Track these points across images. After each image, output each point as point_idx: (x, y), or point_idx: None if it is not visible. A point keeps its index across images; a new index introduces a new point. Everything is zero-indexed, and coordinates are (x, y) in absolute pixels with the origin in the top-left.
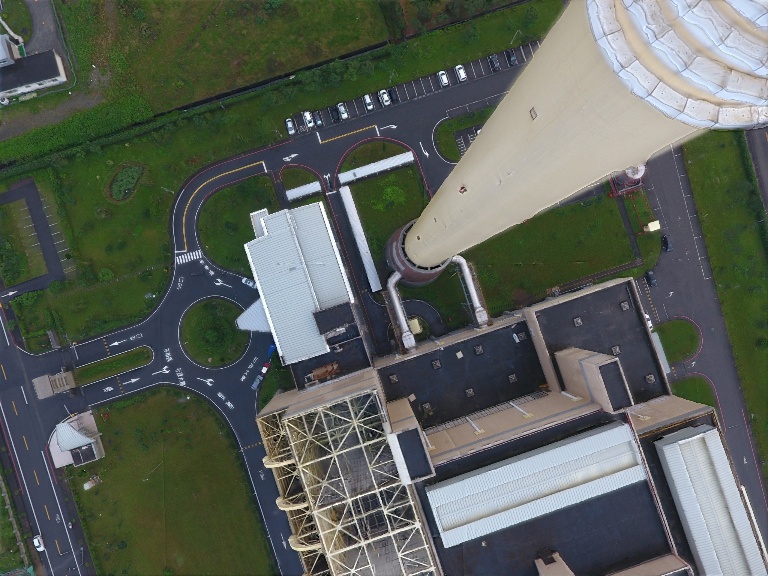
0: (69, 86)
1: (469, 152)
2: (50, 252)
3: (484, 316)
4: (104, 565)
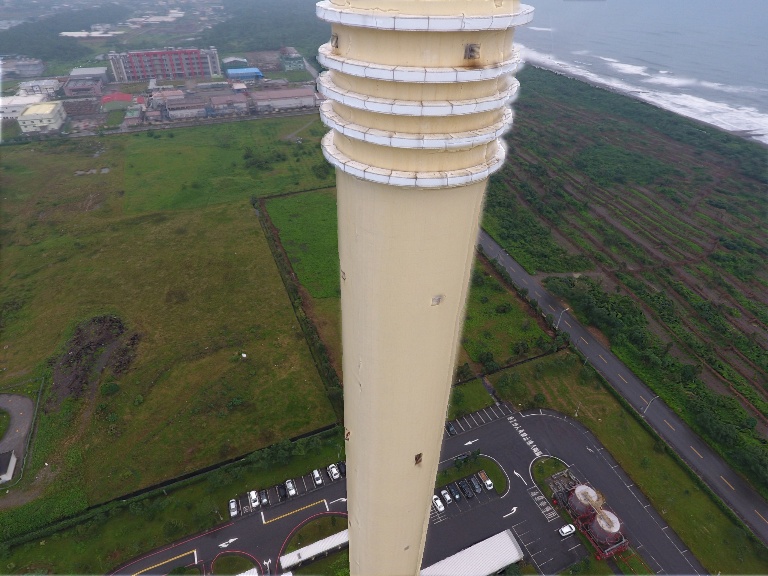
0: (10, 485)
1: None
2: None
3: None
4: None
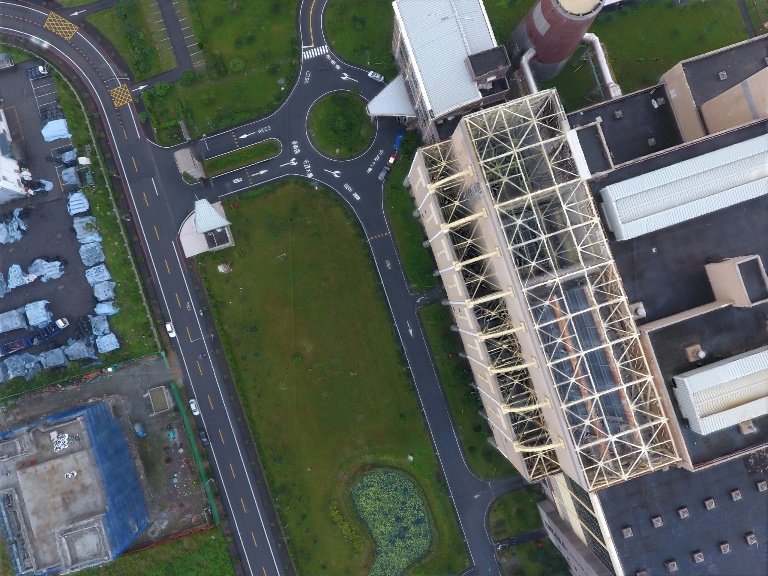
0: None
1: None
2: (180, 46)
3: (618, 91)
4: (234, 351)
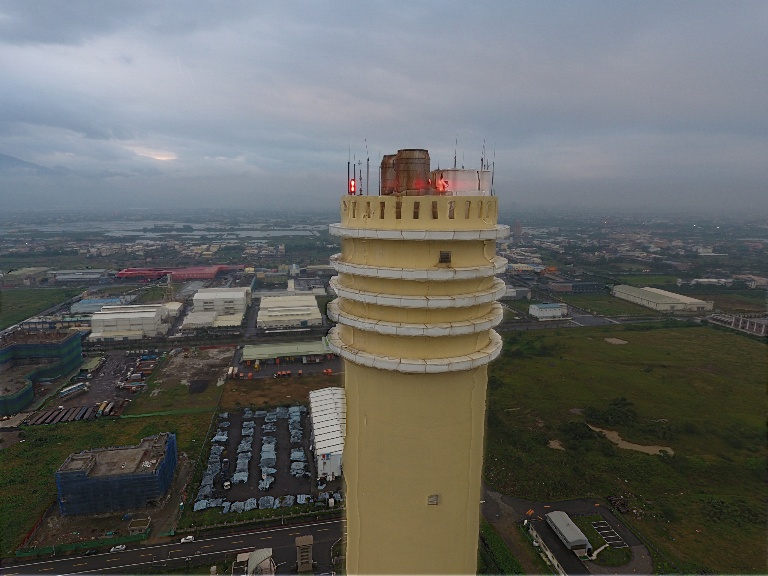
0: None
1: None
2: None
3: None
4: None
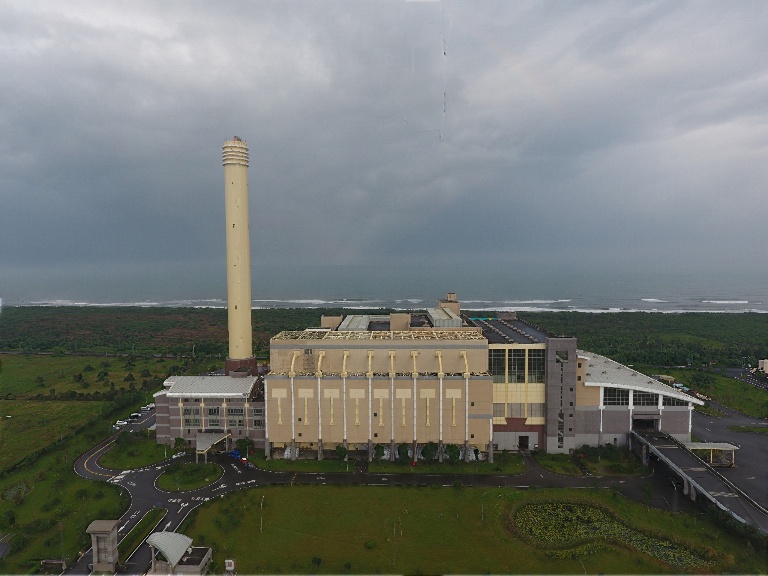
0: None
1: (228, 219)
2: None
3: None
4: None
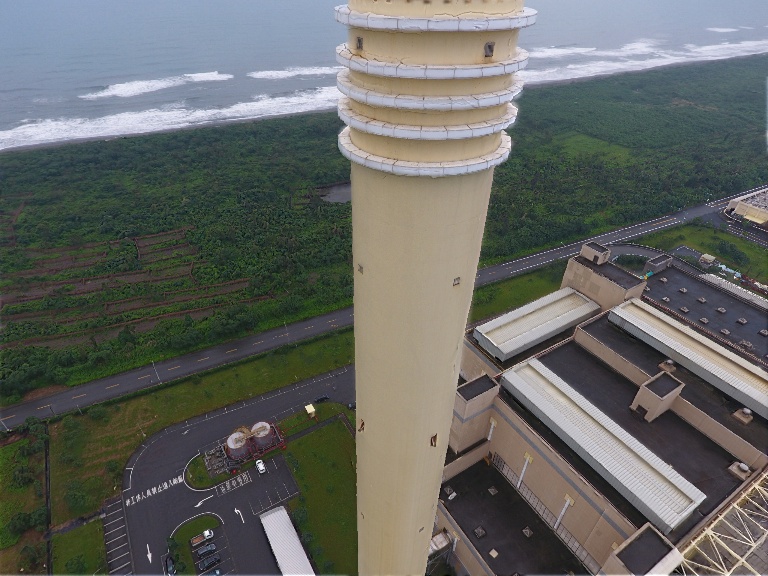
0: None
1: (409, 426)
2: None
3: (439, 539)
4: None
